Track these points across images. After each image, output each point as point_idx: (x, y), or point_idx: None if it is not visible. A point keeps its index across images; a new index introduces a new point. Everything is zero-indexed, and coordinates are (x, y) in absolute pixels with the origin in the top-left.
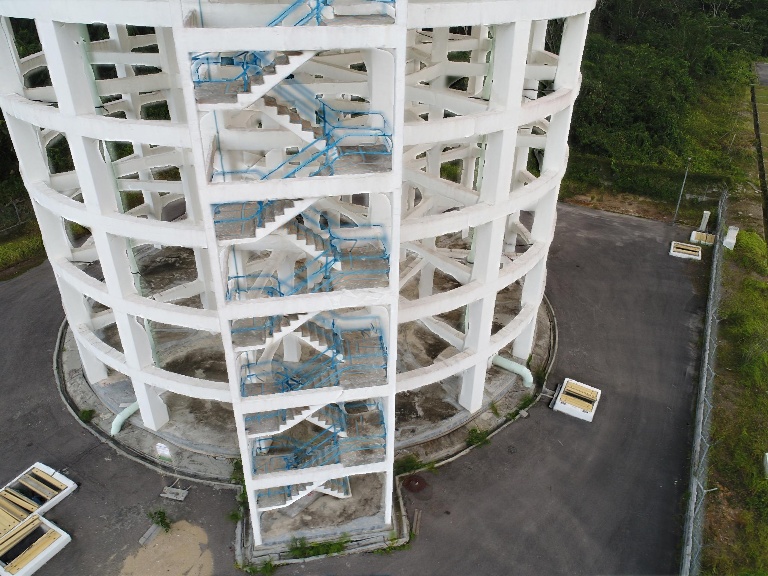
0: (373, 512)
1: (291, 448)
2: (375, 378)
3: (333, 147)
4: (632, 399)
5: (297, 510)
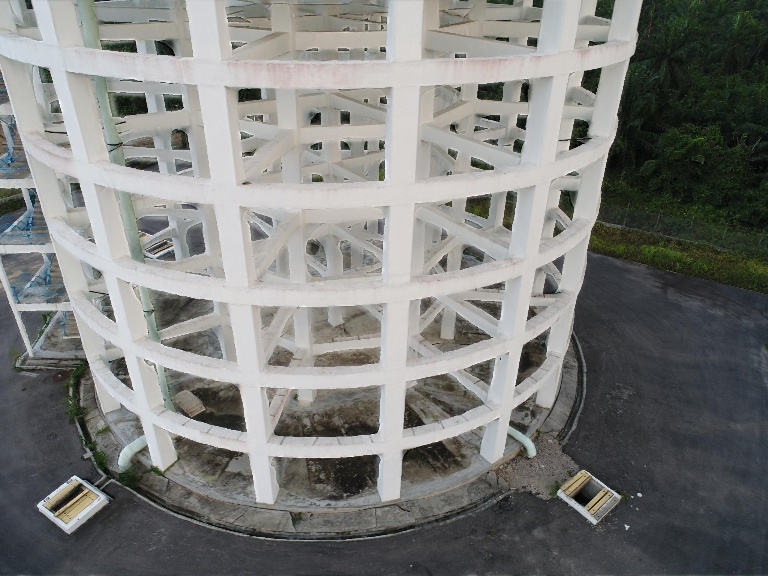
0: (43, 347)
1: None
2: (2, 240)
3: None
4: (44, 571)
5: None
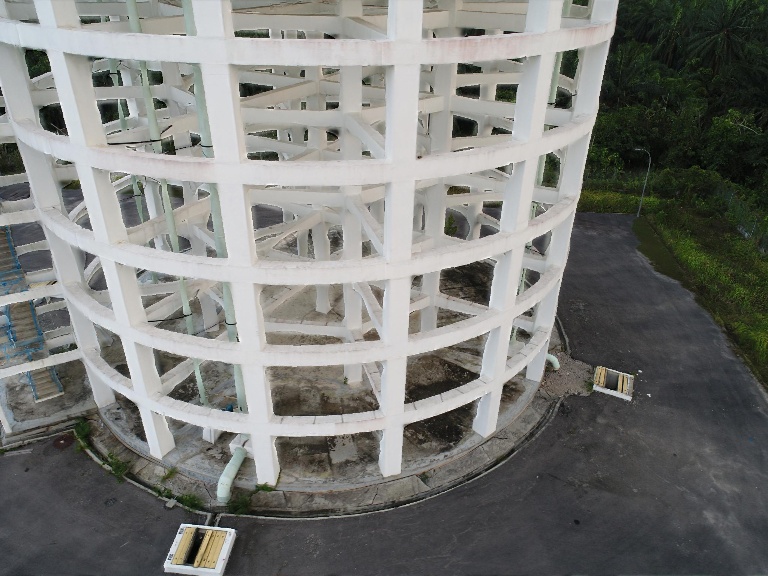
0: (18, 418)
1: None
2: None
3: None
4: None
5: (26, 381)
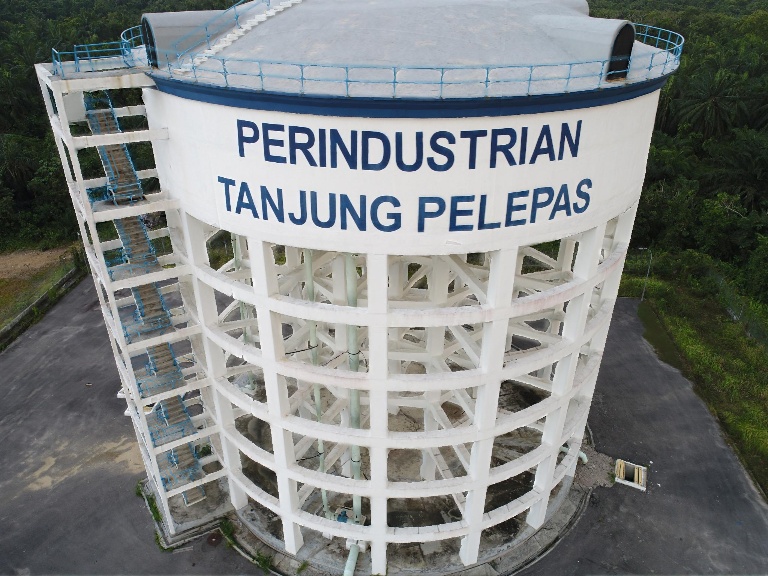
0: (177, 521)
1: (221, 465)
2: None
3: (140, 318)
4: None
5: None
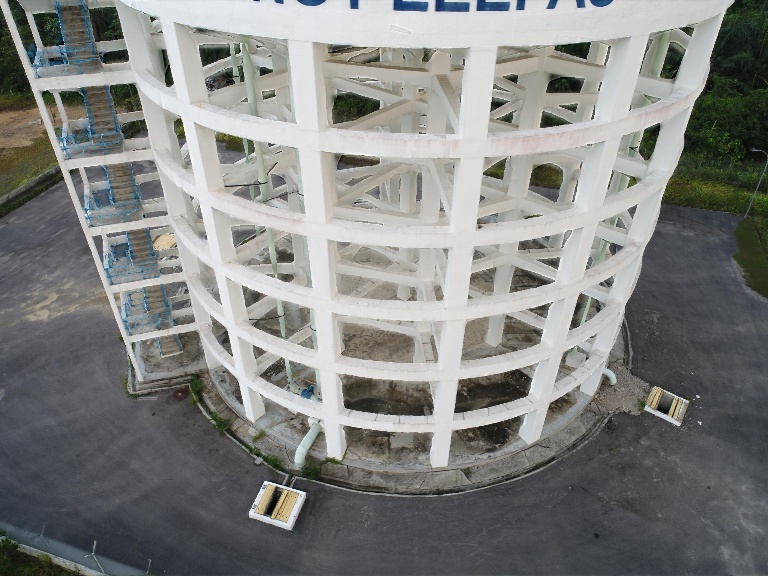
0: (148, 370)
1: None
2: (112, 279)
3: None
4: (289, 564)
5: None
